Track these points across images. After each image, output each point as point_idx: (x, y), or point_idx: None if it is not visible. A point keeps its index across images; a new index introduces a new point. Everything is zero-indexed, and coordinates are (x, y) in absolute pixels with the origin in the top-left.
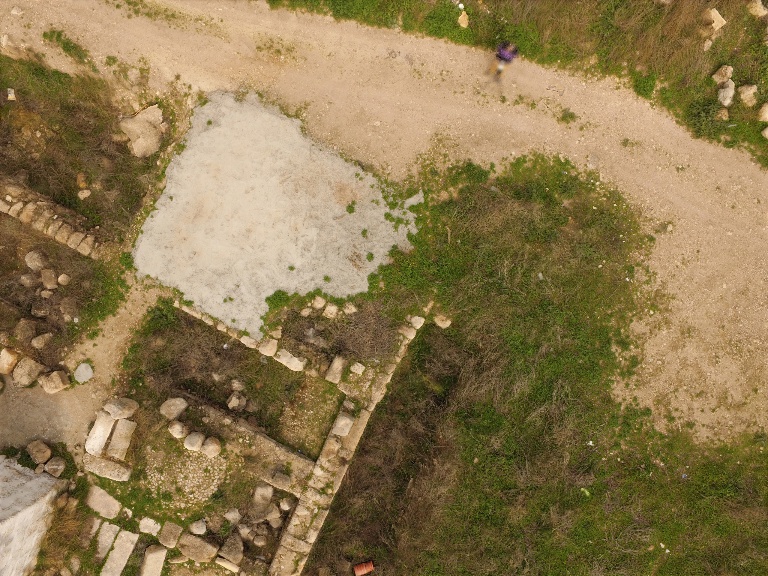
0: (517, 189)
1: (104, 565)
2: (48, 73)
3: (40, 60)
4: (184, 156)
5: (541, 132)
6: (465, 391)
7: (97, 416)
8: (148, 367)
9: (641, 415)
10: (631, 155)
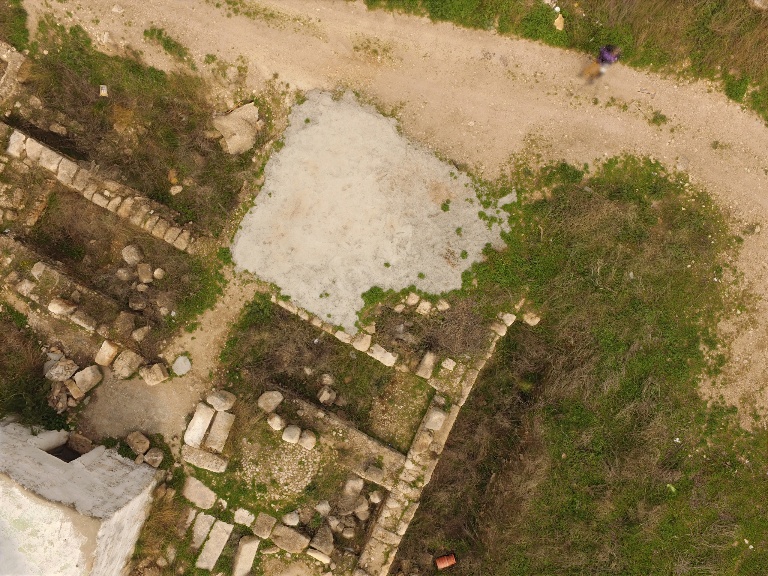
0: (609, 189)
1: (200, 555)
2: (144, 70)
3: (137, 57)
4: (283, 153)
5: (632, 134)
6: (555, 387)
7: (197, 408)
8: (244, 360)
9: (727, 413)
10: (720, 157)
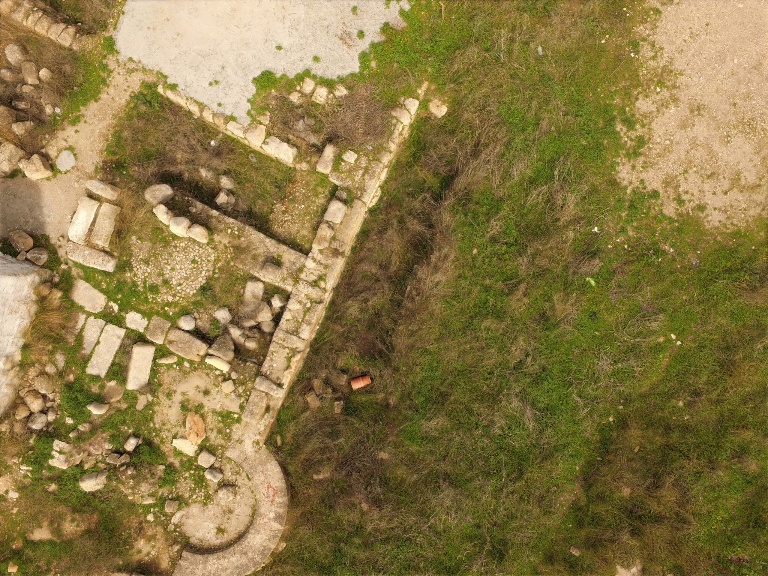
0: None
1: (90, 360)
2: None
3: None
4: None
5: None
6: (462, 176)
7: (80, 200)
8: (132, 156)
9: (649, 198)
10: None
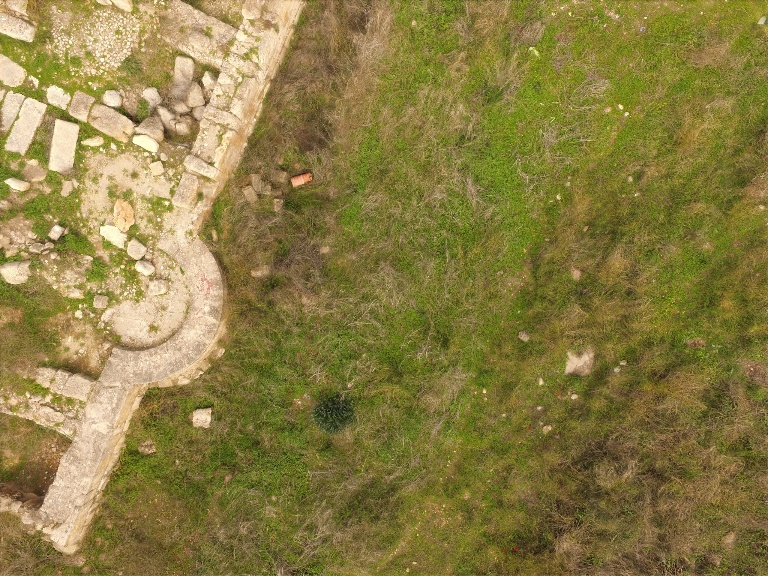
0: None
1: (9, 136)
2: None
3: None
4: None
5: None
6: None
7: None
8: None
9: None
10: None
